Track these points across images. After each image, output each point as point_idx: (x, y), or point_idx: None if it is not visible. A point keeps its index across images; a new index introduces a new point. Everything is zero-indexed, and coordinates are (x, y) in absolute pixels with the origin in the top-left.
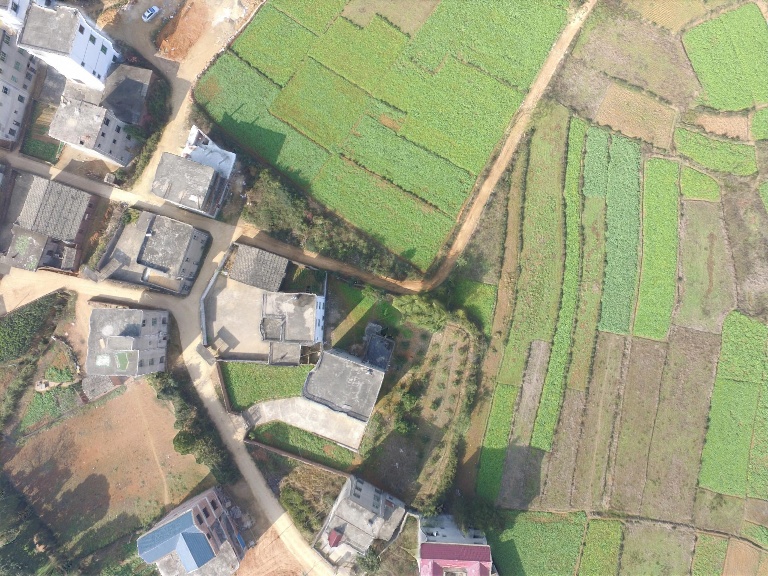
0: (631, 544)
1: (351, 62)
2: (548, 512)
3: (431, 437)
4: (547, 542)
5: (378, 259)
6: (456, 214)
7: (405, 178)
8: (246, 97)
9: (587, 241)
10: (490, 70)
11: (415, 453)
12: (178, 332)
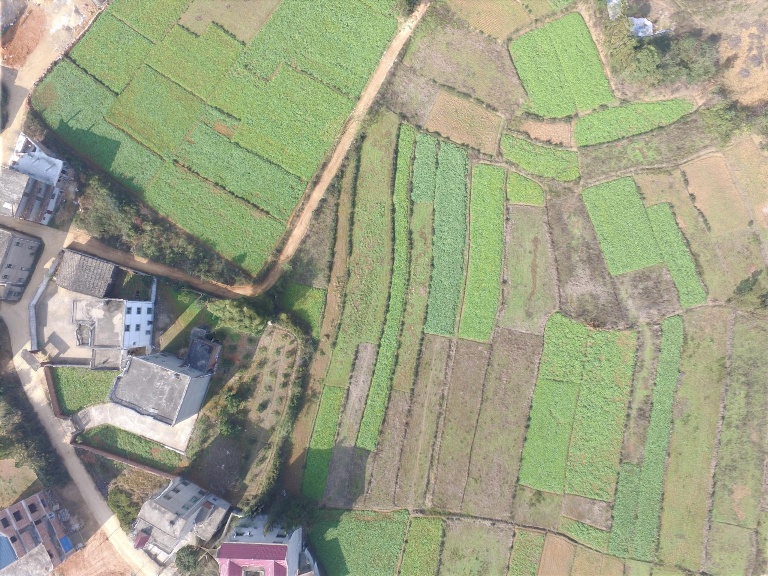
0: (452, 541)
1: (187, 70)
2: (372, 511)
3: (258, 439)
4: (370, 540)
5: (205, 264)
6: (287, 219)
7: (237, 184)
8: (82, 104)
9: (415, 245)
10: (322, 78)
11: (242, 455)
12: (9, 338)
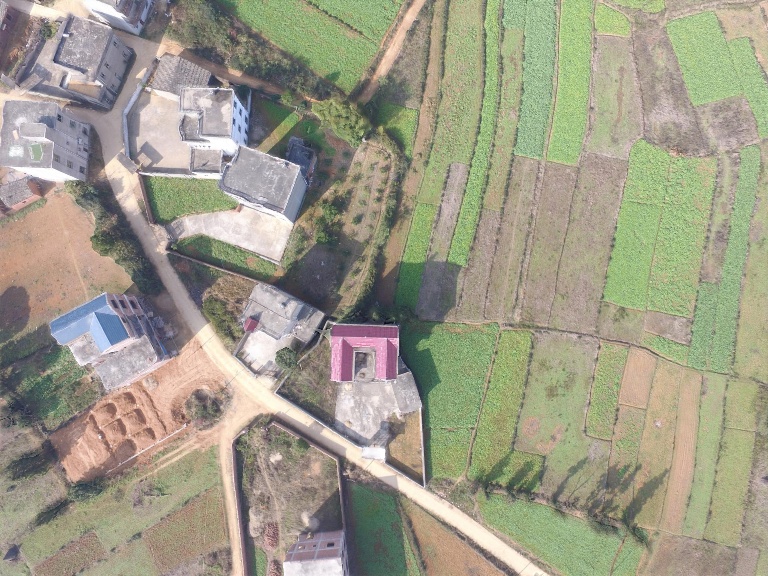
0: (540, 352)
1: None
2: (463, 323)
3: (352, 252)
4: (461, 350)
5: (302, 77)
6: (380, 40)
7: (331, 3)
8: None
9: (505, 70)
10: None
11: (336, 266)
12: (100, 146)
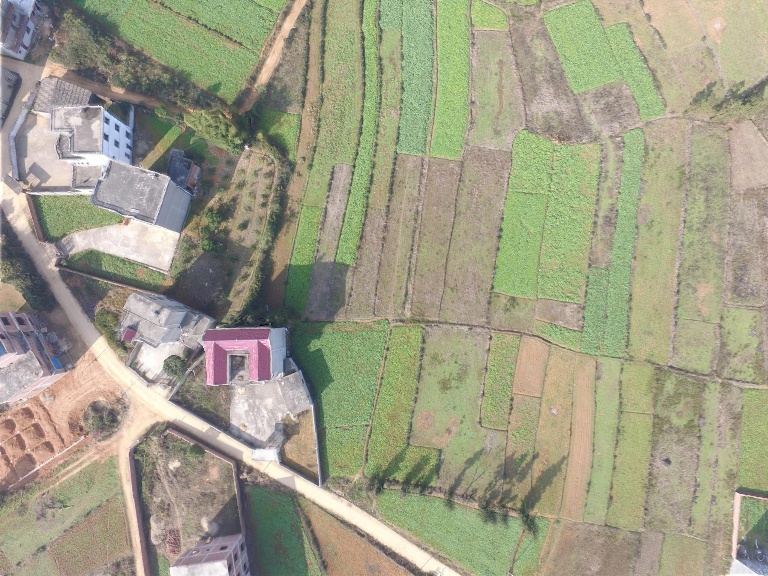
0: (431, 346)
1: None
2: (353, 322)
3: (240, 257)
4: (352, 349)
5: (181, 90)
6: (260, 49)
7: (210, 17)
8: None
9: (385, 71)
10: None
11: (224, 273)
12: None
